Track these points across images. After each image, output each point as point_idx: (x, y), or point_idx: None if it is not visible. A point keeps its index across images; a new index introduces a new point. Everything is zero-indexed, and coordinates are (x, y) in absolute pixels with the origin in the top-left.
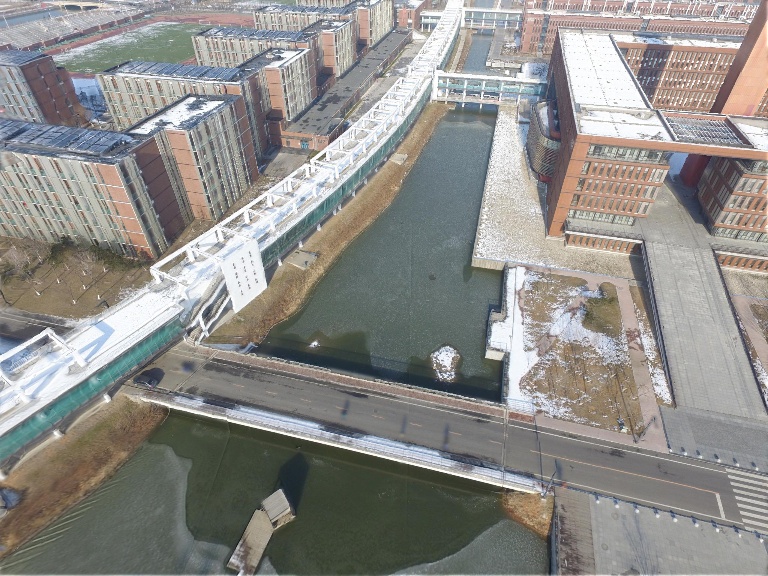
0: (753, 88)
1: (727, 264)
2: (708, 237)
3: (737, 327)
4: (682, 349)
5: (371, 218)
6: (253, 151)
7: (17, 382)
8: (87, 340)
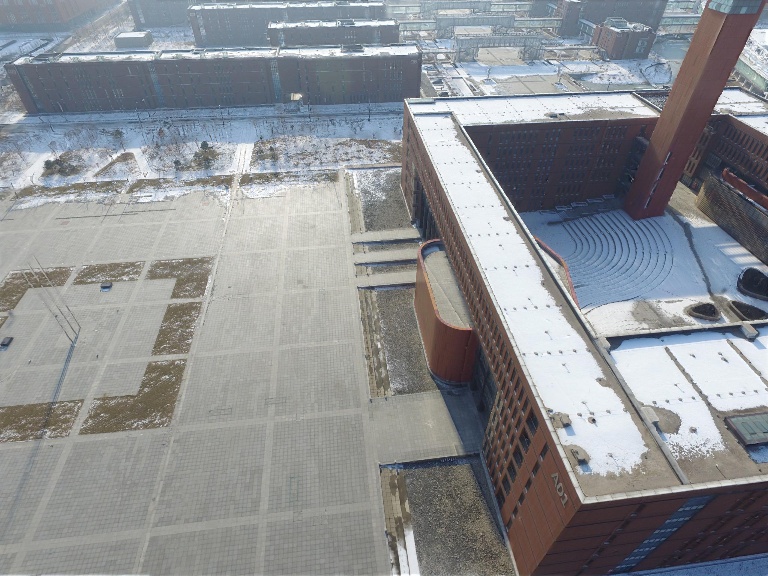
0: None
1: None
2: None
3: None
4: None
5: None
6: None
7: (760, 56)
8: None
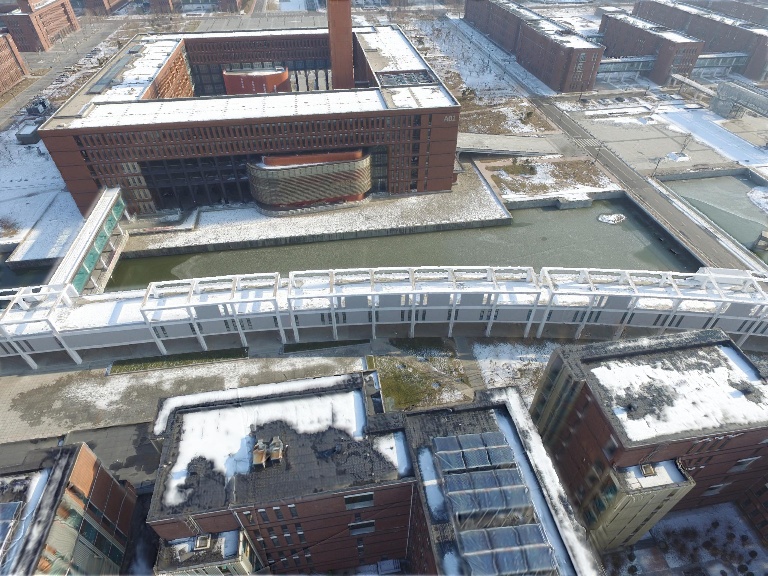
0: None
1: None
2: None
3: None
4: (526, 148)
5: None
6: None
7: None
8: None
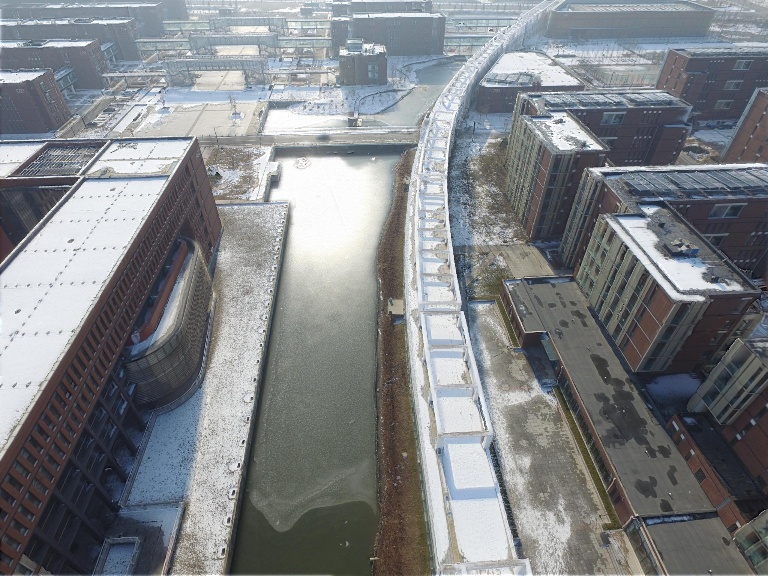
0: None
1: None
2: None
3: None
4: None
5: (387, 229)
6: (537, 211)
7: (447, 87)
8: (453, 107)
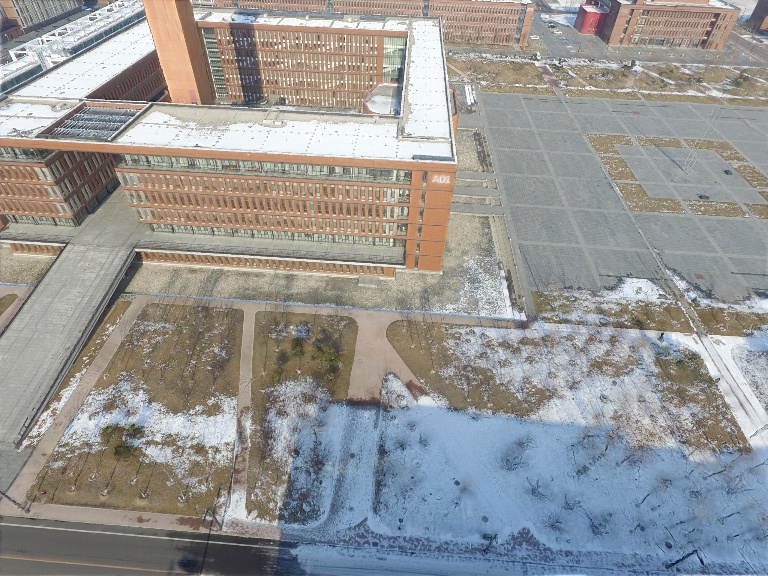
0: (181, 73)
1: (168, 260)
2: (146, 233)
3: (81, 335)
4: None
5: None
6: None
7: None
8: None
